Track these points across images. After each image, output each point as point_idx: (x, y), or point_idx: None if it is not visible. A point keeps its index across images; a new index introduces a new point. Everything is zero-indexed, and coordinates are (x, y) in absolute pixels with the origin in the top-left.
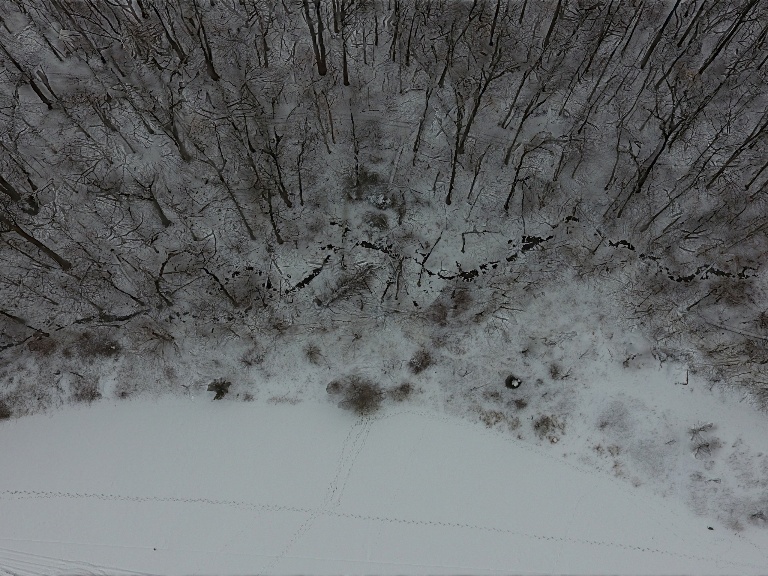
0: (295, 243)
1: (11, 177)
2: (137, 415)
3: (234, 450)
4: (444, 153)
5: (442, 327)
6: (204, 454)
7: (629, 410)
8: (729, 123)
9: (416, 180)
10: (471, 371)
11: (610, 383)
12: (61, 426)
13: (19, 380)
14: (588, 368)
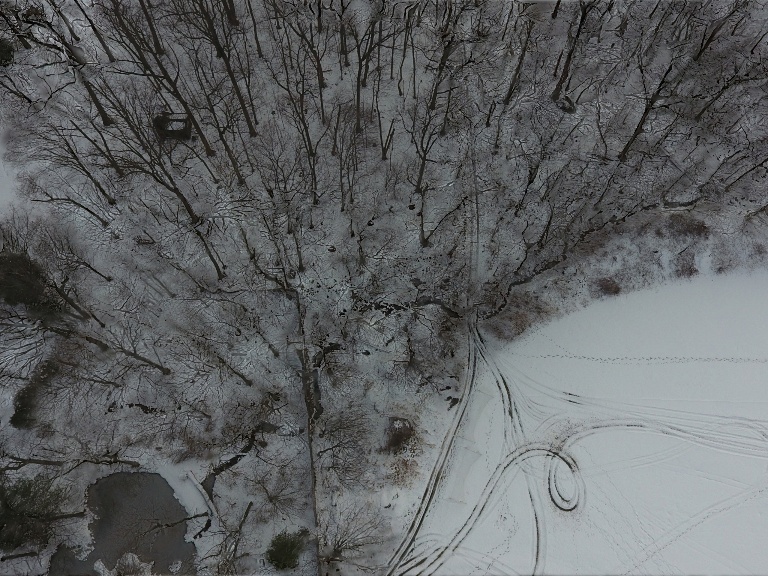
0: None
1: (544, 79)
2: (735, 288)
3: None
4: None
5: None
6: None
7: None
8: None
9: None
10: None
11: None
12: (669, 300)
13: (622, 258)
14: None
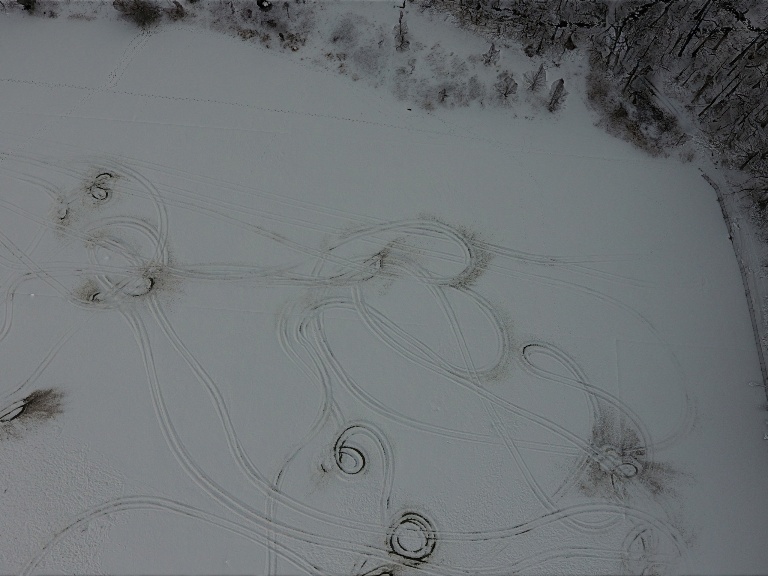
0: None
1: None
2: None
3: (37, 49)
4: None
5: None
6: (13, 51)
7: (355, 25)
8: None
9: None
10: None
11: (342, 6)
12: None
13: None
14: None
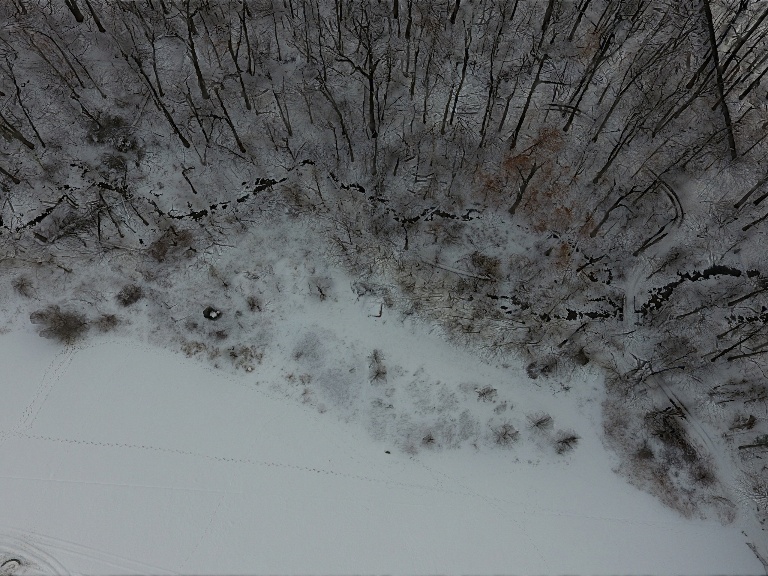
0: (26, 182)
1: None
2: None
3: None
4: None
5: (159, 263)
6: None
7: (321, 341)
8: (474, 71)
9: (159, 124)
10: (177, 304)
11: (306, 315)
12: None
13: None
14: (286, 301)
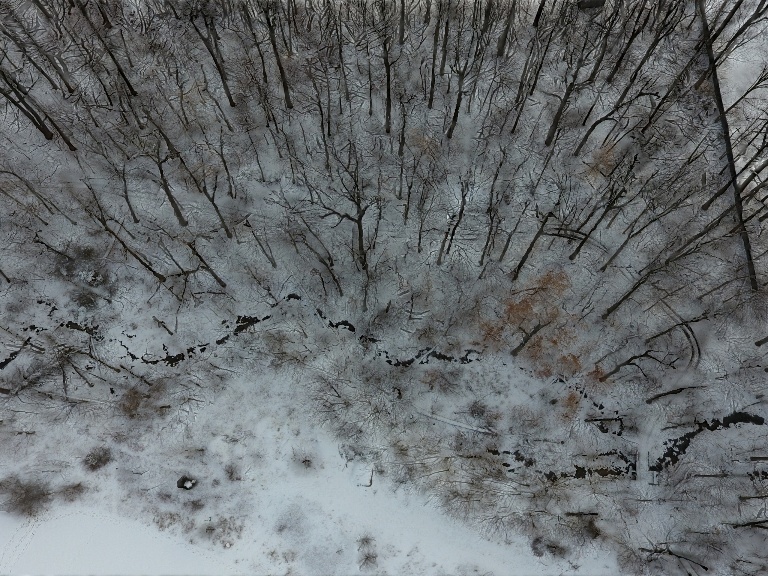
0: None
1: None
2: None
3: None
4: (167, 225)
5: (131, 418)
6: None
7: (306, 514)
8: (472, 192)
9: None
10: (149, 469)
11: (289, 484)
12: None
13: None
14: (268, 468)
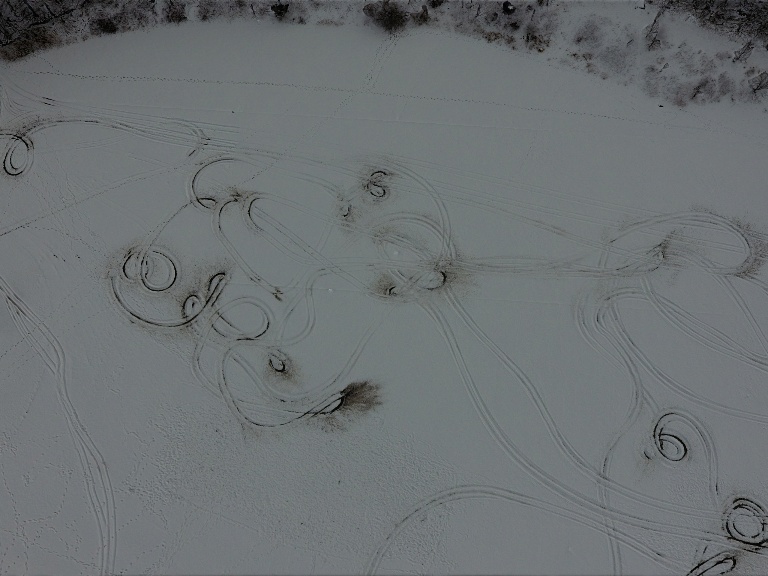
0: None
1: None
2: (215, 32)
3: (292, 54)
4: None
5: None
6: (268, 56)
7: (599, 26)
8: None
9: None
10: (476, 3)
11: (584, 8)
12: (156, 38)
13: (123, 5)
14: None
